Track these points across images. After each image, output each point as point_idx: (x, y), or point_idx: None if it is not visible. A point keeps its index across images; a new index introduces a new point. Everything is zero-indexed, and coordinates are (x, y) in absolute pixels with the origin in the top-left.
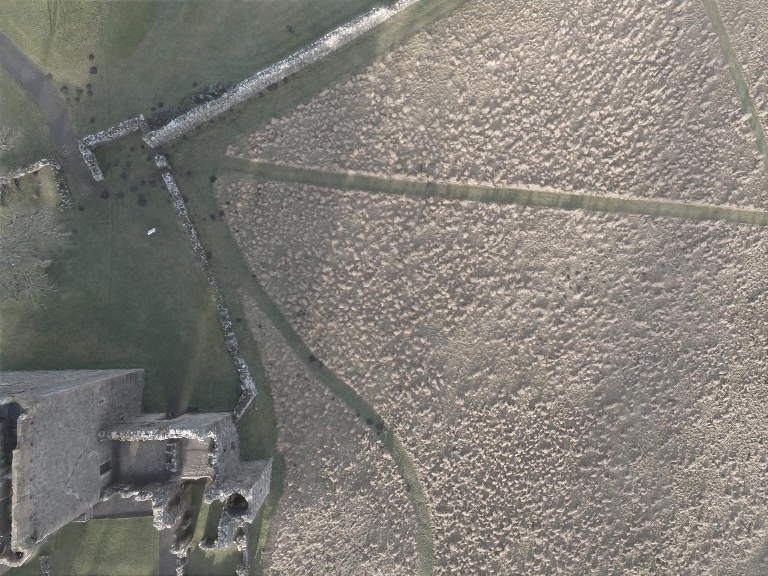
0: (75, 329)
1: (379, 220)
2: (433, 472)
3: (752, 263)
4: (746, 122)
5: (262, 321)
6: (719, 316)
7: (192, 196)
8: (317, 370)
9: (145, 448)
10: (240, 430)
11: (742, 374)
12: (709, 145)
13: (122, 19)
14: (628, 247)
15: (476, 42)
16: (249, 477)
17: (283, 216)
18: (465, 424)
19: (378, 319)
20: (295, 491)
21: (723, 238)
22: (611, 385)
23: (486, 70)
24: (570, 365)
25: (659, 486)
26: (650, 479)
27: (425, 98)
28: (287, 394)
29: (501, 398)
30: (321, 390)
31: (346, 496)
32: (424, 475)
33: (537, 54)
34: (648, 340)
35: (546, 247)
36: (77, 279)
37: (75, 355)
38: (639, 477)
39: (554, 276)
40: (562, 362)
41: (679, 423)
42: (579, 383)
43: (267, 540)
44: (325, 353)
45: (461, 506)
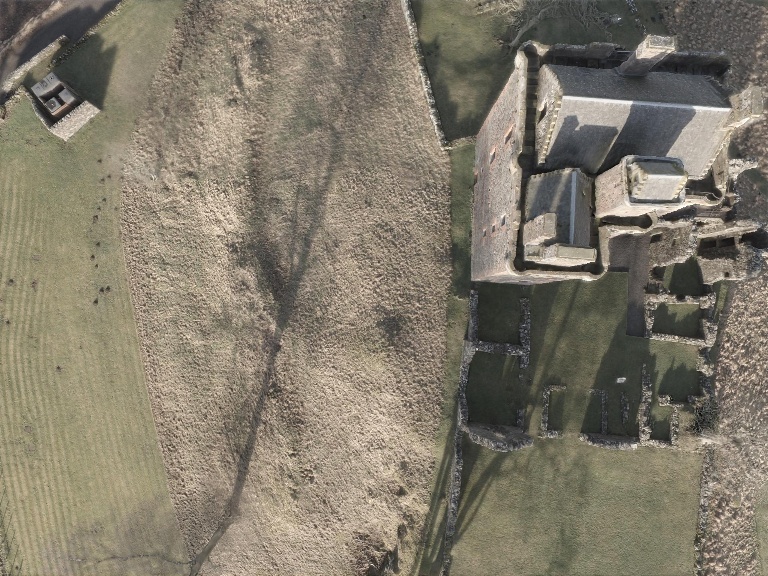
0: None
1: None
2: None
3: None
4: None
5: None
6: None
7: None
8: None
9: None
10: None
11: None
12: None
13: None
14: None
15: None
16: None
17: (714, 25)
18: None
19: None
20: None
21: None
22: None
23: None
24: None
25: None
26: None
27: None
28: None
29: None
30: (750, 184)
31: None
32: None
33: None
34: None
35: None
36: None
37: None
38: None
39: None
40: None
41: None
42: None
43: (725, 303)
44: (751, 152)
45: None
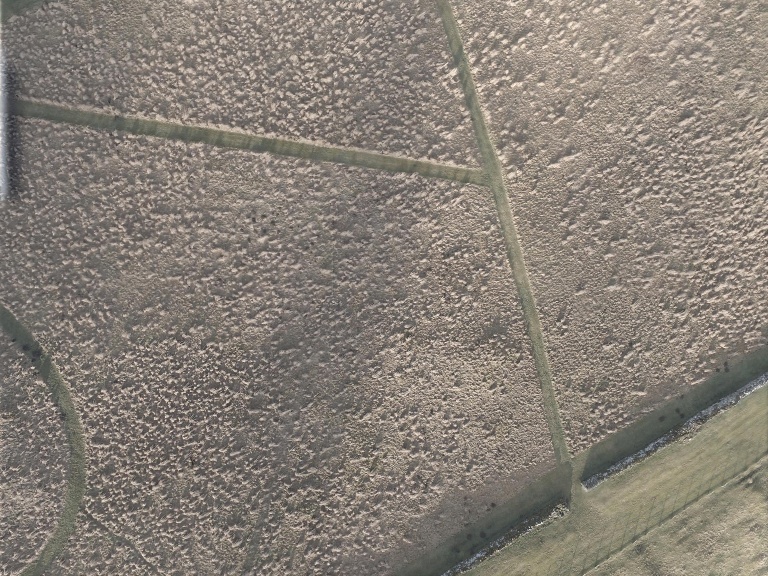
0: None
1: (59, 149)
2: (89, 402)
3: (450, 220)
4: (456, 77)
5: None
6: (411, 270)
7: None
8: None
9: None
10: None
11: (430, 330)
12: (412, 98)
13: None
14: (319, 194)
15: None
16: None
17: None
18: (130, 358)
19: (47, 247)
20: None
21: (418, 192)
22: (291, 331)
23: (184, 7)
24: (248, 308)
25: (330, 434)
26: (321, 427)
27: (119, 31)
28: None
29: (172, 335)
30: None
31: None
32: (81, 405)
33: None
34: (333, 289)
35: (232, 188)
36: None
37: None
38: (310, 424)
39: (238, 218)
40: (240, 304)
41: (358, 373)
42: (255, 326)
43: None
44: None
45: (119, 439)
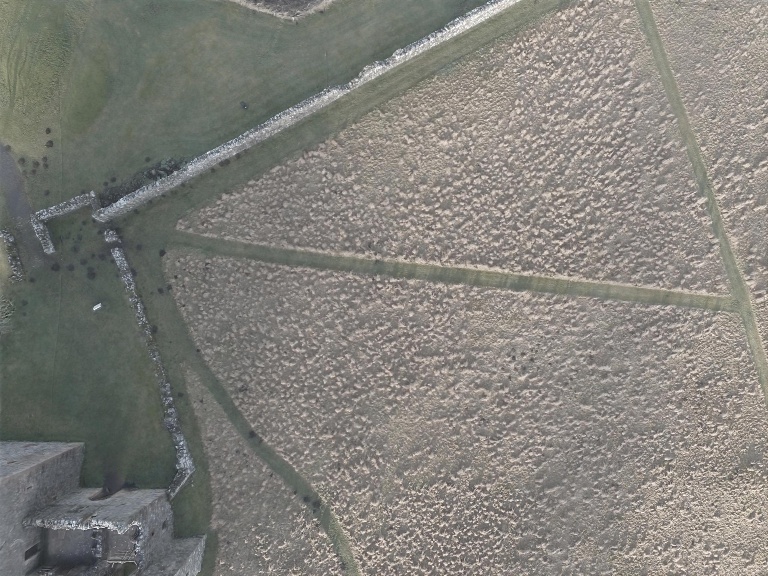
0: (20, 400)
1: (325, 297)
2: (368, 551)
3: (703, 348)
4: (702, 205)
5: (204, 396)
6: (667, 401)
7: (141, 269)
8: (257, 446)
9: (73, 531)
10: (175, 507)
11: (688, 460)
12: (663, 228)
13: (78, 95)
14: (576, 329)
15: (429, 121)
16: (174, 562)
17: (230, 291)
18: (403, 503)
19: (320, 396)
20: (227, 569)
21: (673, 323)
22: (553, 468)
23: (438, 149)
24: (512, 447)
25: (598, 572)
26: (589, 564)
27: (376, 176)
28: (225, 470)
29: (441, 478)
30: (259, 466)
31: (279, 574)
32: (359, 553)
33: (490, 133)
34: (593, 424)
35: (492, 328)
36: (24, 350)
37: (18, 426)
38: (578, 562)
39: (499, 357)
40: (504, 443)
41: (621, 508)
42: (520, 465)
43: None
44: (265, 429)
45: None
